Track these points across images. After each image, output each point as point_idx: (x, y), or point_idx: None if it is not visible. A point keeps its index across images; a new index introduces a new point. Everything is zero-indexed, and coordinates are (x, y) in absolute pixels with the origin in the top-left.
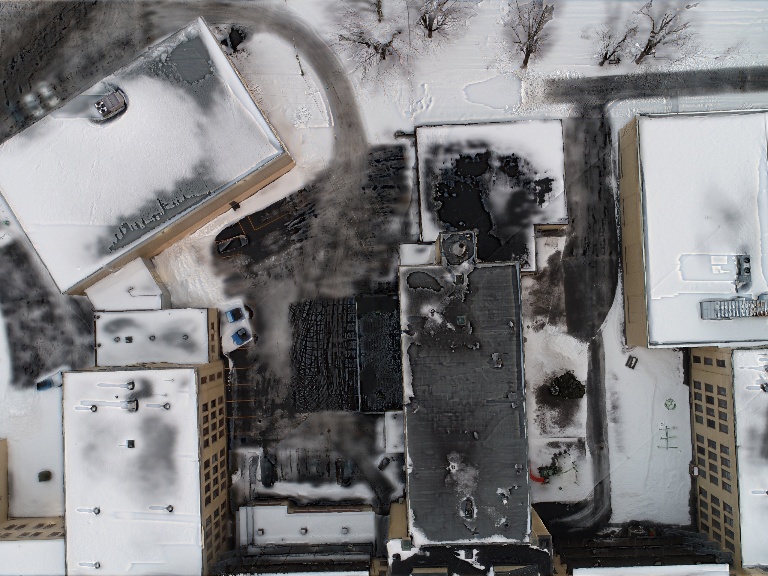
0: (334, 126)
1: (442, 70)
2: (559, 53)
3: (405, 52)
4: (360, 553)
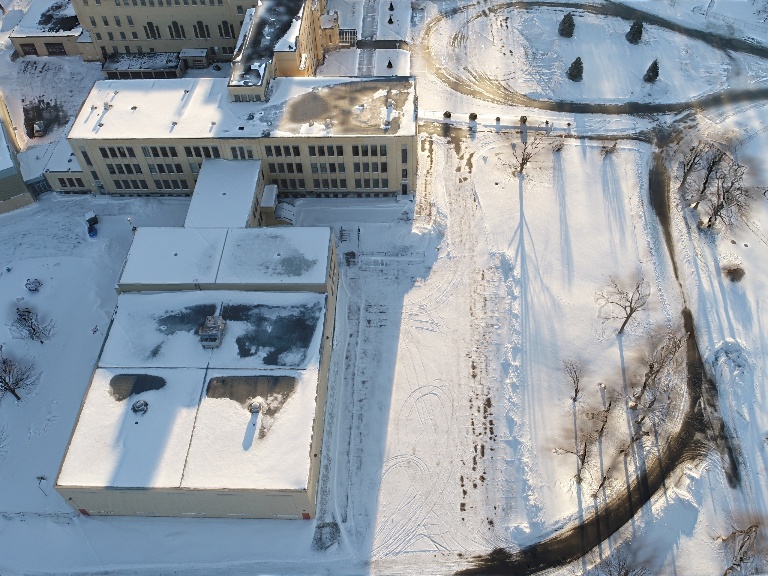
0: None
1: None
2: (5, 2)
3: None
4: None
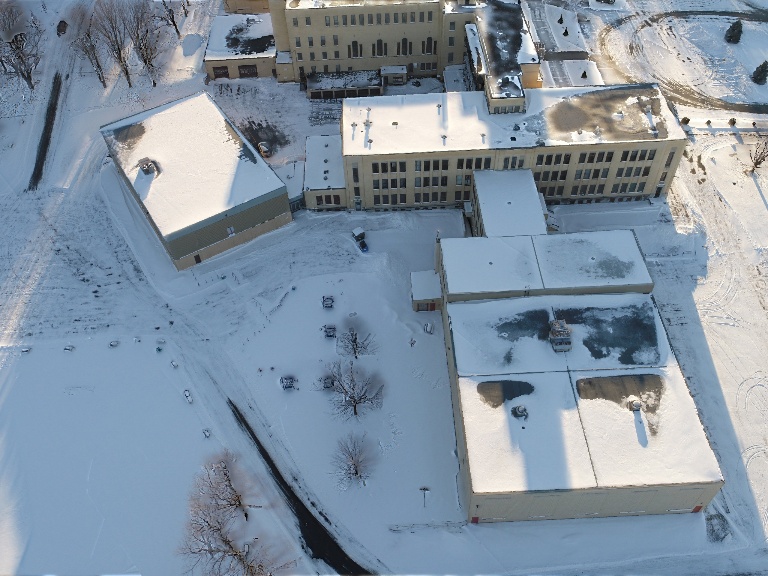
0: None
1: (171, 64)
2: None
3: None
4: None
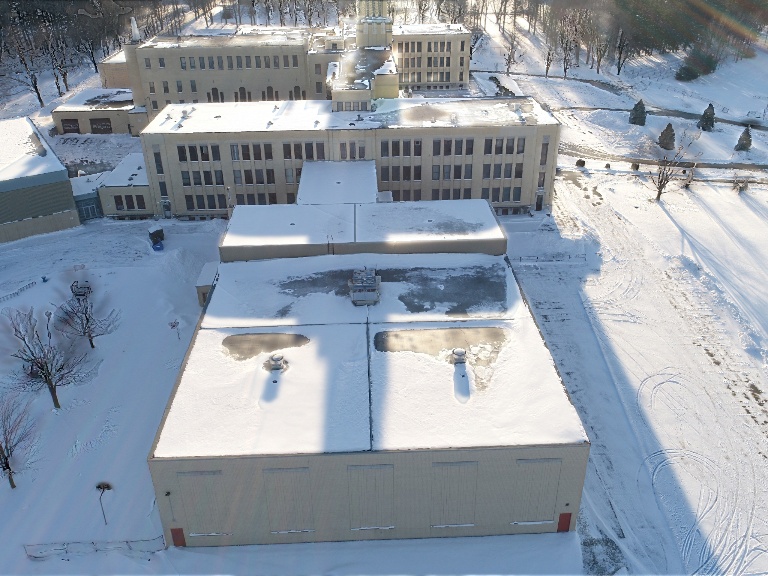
0: None
1: None
2: None
3: None
4: None
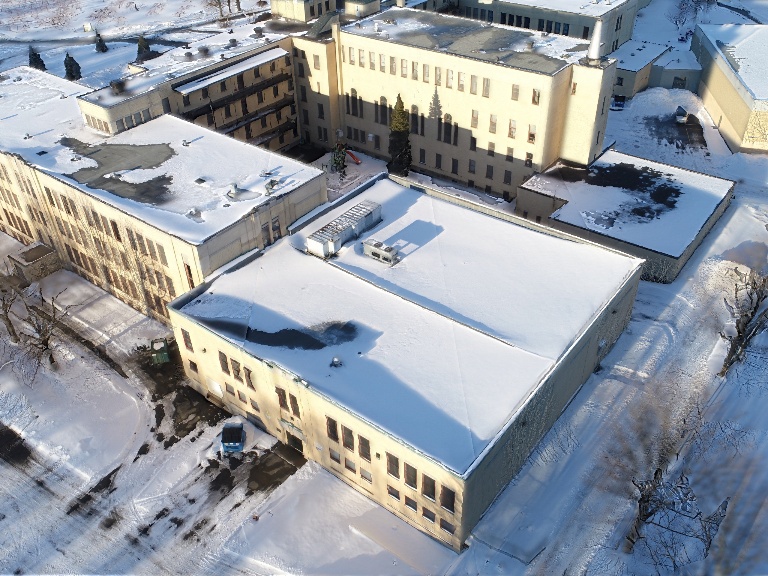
0: (767, 184)
1: None
2: None
3: None
4: None
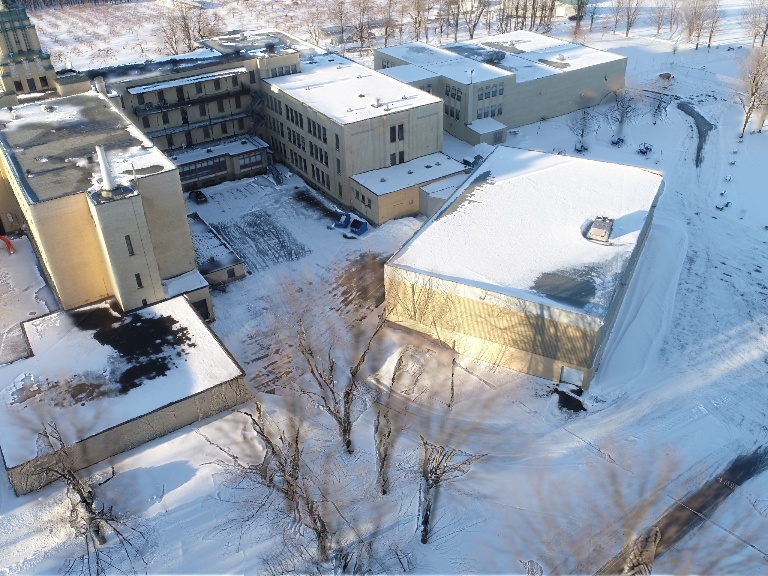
0: None
1: None
2: None
3: (318, 472)
4: (152, 136)
